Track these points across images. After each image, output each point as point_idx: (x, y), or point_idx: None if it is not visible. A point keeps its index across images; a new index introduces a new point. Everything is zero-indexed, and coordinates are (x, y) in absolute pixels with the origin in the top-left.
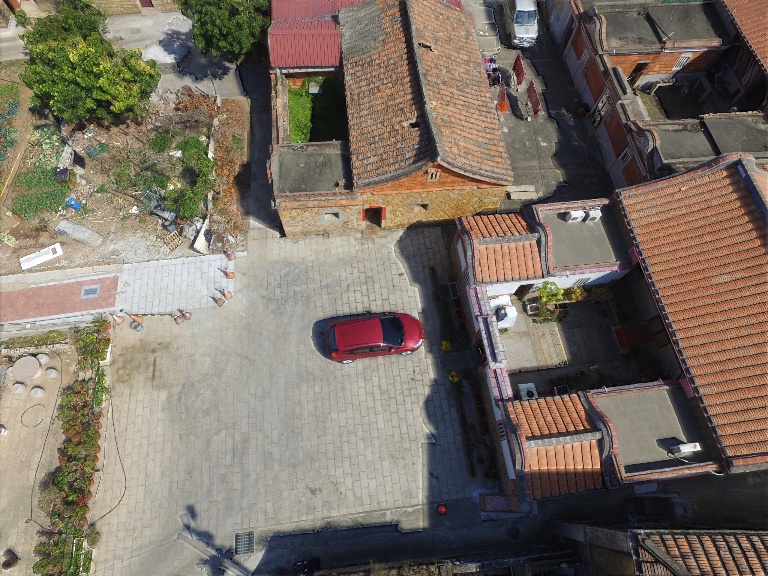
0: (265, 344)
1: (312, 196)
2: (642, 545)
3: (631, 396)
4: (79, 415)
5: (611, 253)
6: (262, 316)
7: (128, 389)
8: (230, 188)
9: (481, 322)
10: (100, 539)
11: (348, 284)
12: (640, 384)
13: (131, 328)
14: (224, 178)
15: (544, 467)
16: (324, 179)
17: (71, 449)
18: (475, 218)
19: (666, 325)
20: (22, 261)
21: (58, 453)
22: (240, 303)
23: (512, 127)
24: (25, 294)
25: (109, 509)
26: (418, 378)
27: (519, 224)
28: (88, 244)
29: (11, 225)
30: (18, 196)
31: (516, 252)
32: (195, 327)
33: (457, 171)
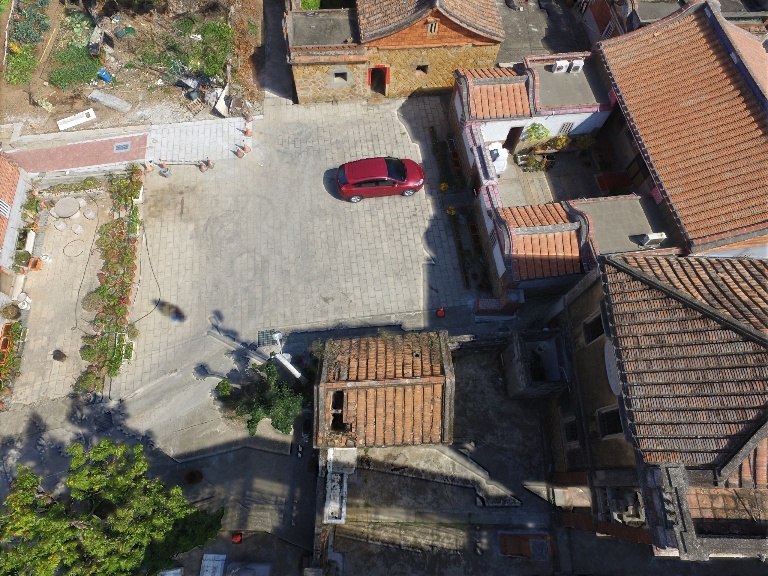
0: (281, 187)
1: (323, 50)
2: (608, 261)
3: (607, 204)
4: (116, 241)
5: (592, 97)
6: (278, 166)
7: (159, 222)
8: (247, 64)
9: (475, 150)
10: (139, 334)
11: (355, 141)
12: (616, 196)
13: (160, 175)
14: (241, 56)
15: (529, 253)
16: (334, 38)
17: (111, 266)
18: (470, 70)
19: (639, 145)
20: (59, 123)
21: (98, 277)
22: (258, 155)
23: (506, 16)
24: (63, 150)
25: (146, 313)
26: (419, 214)
27: (510, 73)
28: (118, 110)
29: (48, 93)
30: (53, 70)
31: (507, 93)
32: (218, 174)
33: (454, 20)
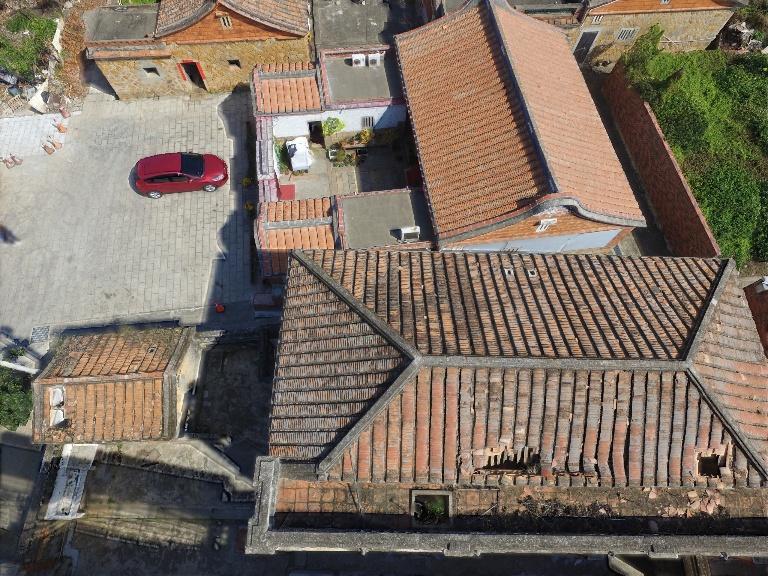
0: (85, 184)
1: (121, 45)
2: (293, 254)
3: (376, 198)
4: None
5: (387, 91)
6: (86, 162)
7: None
8: (74, 60)
9: (258, 145)
10: None
11: (170, 136)
12: (388, 190)
13: None
14: (70, 52)
15: (282, 247)
16: (136, 32)
17: None
18: (270, 65)
19: None
20: None
21: None
22: (68, 152)
23: (347, 10)
24: None
25: None
26: (220, 210)
27: (307, 67)
28: None
29: None
30: None
31: (297, 87)
32: (24, 171)
33: (242, 14)
